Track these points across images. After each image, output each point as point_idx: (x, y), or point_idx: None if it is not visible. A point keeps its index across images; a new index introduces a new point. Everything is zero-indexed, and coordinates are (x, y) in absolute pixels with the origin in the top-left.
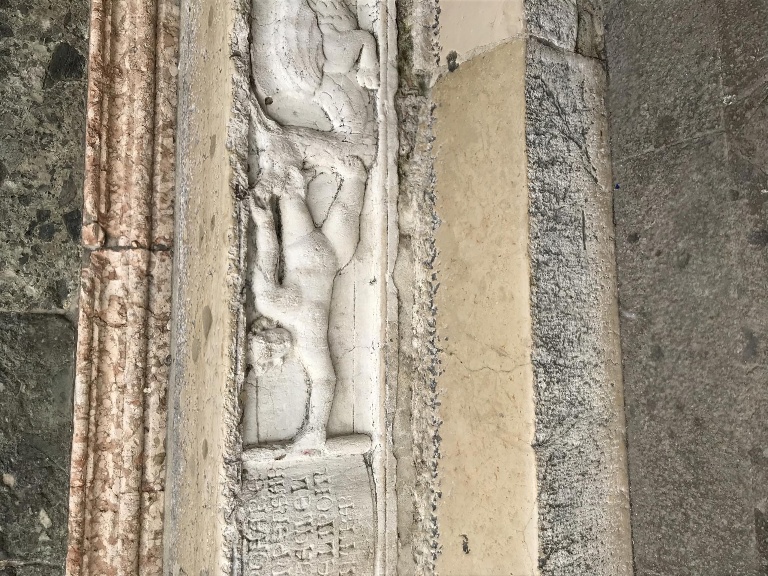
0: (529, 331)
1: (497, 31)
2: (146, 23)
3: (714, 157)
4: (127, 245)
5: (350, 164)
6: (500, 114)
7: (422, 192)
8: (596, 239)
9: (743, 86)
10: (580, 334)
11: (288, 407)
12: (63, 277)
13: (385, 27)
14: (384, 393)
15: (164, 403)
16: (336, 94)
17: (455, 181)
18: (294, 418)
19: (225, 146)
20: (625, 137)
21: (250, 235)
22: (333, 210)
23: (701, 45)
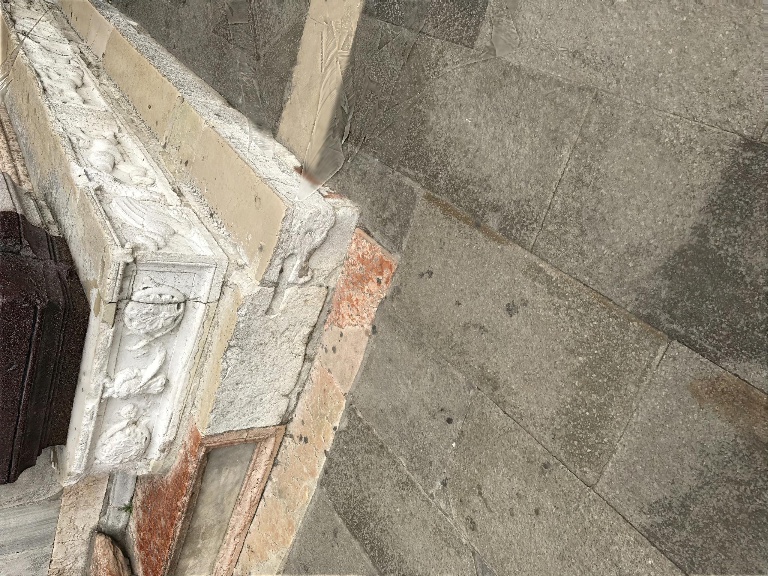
0: None
1: None
2: None
3: None
4: None
5: (73, 71)
6: None
7: None
8: None
9: None
10: None
11: None
12: None
13: (78, 59)
14: (105, 99)
15: None
16: (62, 64)
17: None
18: None
19: None
20: None
21: None
22: None
23: (161, 5)
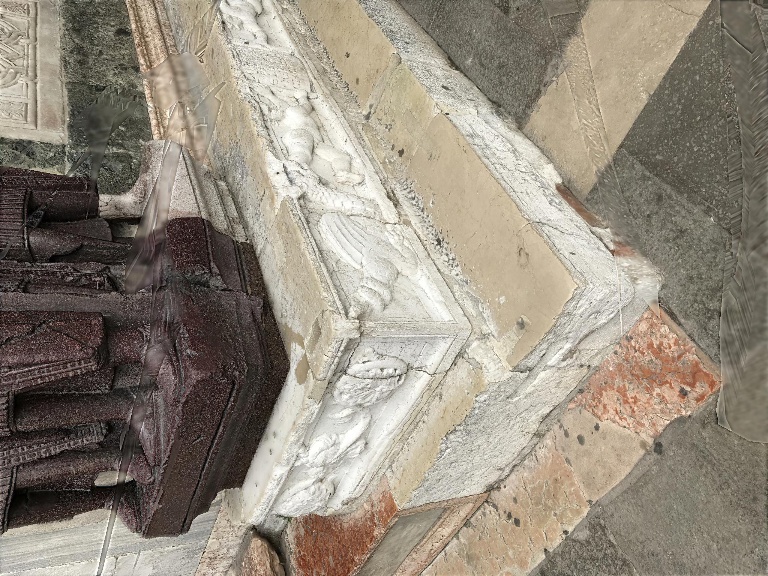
0: None
1: None
2: None
3: None
4: None
5: None
6: None
7: (288, 0)
8: None
9: None
10: None
11: None
12: (134, 82)
13: None
14: (291, 36)
15: None
16: None
17: None
18: None
19: None
20: None
21: None
22: None
23: None
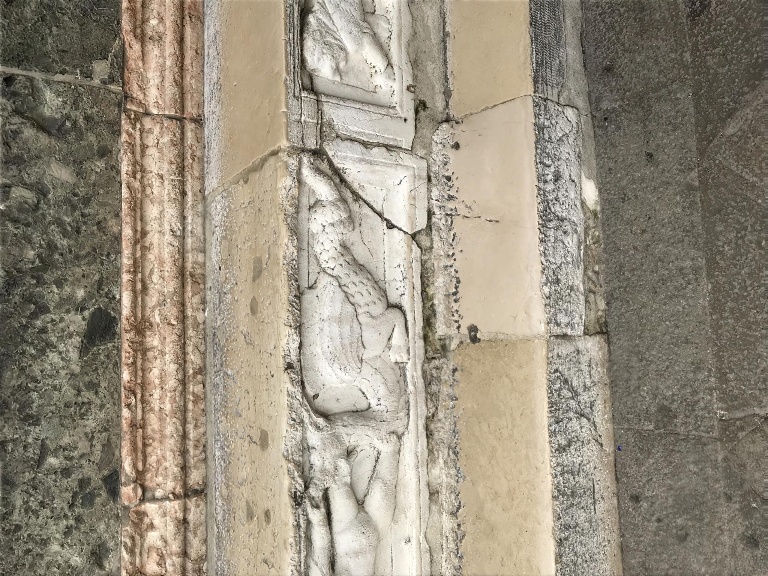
0: None
1: (519, 326)
2: (175, 277)
3: (709, 458)
4: (164, 497)
5: (387, 442)
6: (524, 403)
7: (447, 449)
8: (603, 500)
9: (734, 409)
10: None
11: None
12: (104, 539)
13: (412, 303)
14: None
15: None
16: (374, 378)
17: (479, 446)
18: None
19: (282, 455)
20: (626, 408)
21: (306, 532)
22: (374, 488)
23: (696, 358)
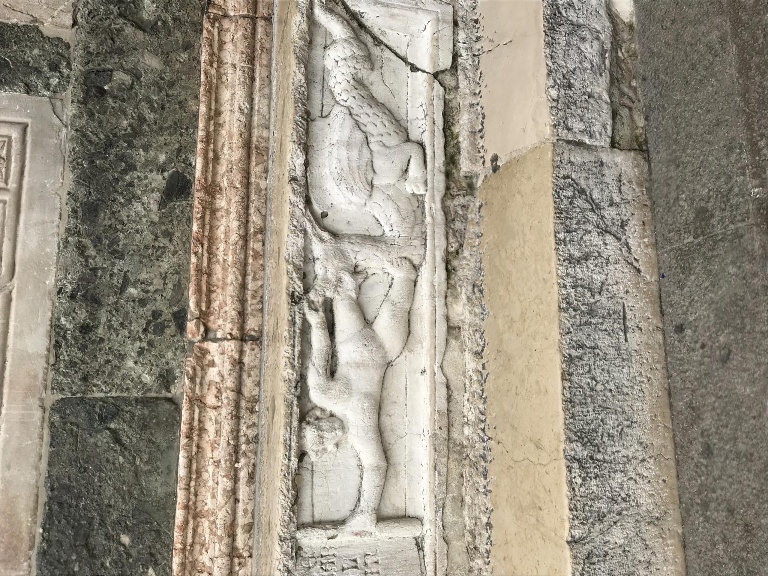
0: (561, 426)
1: (528, 136)
2: (241, 147)
3: (746, 250)
4: (223, 337)
5: (398, 265)
6: (532, 214)
7: (471, 285)
8: (640, 330)
9: (767, 179)
10: (622, 428)
11: (342, 490)
12: (172, 366)
13: (432, 137)
14: (433, 479)
15: (252, 477)
16: (385, 203)
17: (499, 275)
18: (347, 500)
19: (284, 258)
20: (667, 227)
21: (306, 334)
22: (383, 308)
23: (728, 138)
